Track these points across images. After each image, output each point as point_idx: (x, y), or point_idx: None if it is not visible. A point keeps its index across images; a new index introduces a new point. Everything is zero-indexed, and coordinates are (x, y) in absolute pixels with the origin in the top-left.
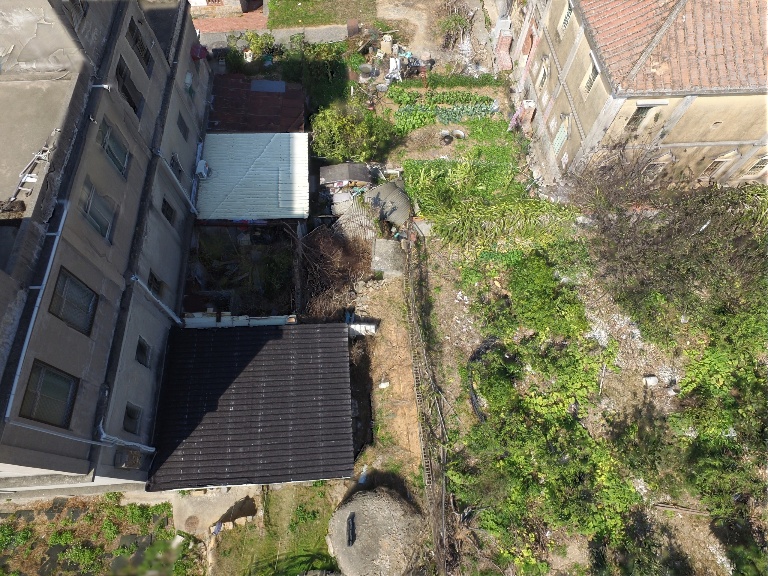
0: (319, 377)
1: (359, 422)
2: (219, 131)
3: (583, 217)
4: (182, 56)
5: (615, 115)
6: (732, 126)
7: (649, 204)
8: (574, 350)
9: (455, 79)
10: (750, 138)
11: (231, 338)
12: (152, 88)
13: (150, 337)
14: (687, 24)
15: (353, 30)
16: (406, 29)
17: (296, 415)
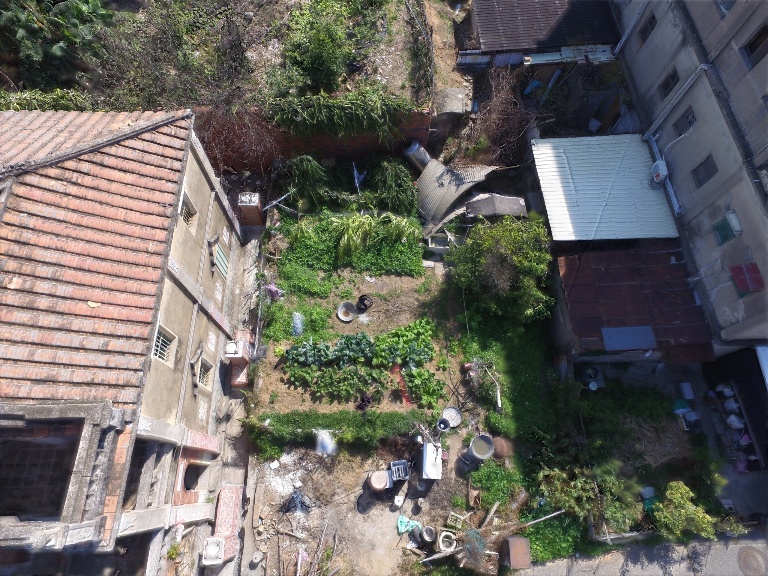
0: (499, 19)
1: (462, 36)
2: (665, 249)
3: None
4: (759, 221)
5: None
6: None
7: None
8: None
9: (335, 422)
10: None
11: (572, 37)
12: (754, 98)
13: (633, 3)
14: None
15: None
16: None
17: (512, 1)
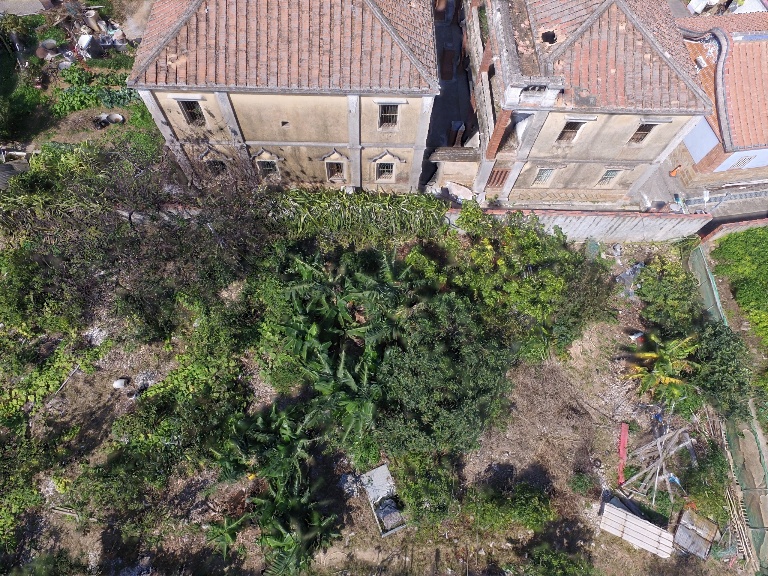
0: None
1: None
2: None
3: (127, 212)
4: None
5: (158, 108)
6: (305, 127)
7: (194, 203)
8: (60, 347)
9: None
10: (339, 140)
11: None
12: None
13: None
14: (210, 16)
15: (47, 3)
16: (128, 5)
17: None
